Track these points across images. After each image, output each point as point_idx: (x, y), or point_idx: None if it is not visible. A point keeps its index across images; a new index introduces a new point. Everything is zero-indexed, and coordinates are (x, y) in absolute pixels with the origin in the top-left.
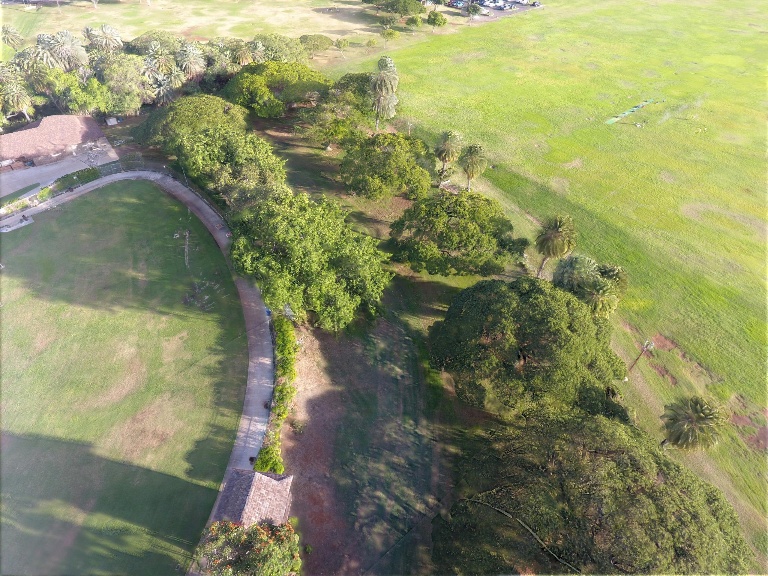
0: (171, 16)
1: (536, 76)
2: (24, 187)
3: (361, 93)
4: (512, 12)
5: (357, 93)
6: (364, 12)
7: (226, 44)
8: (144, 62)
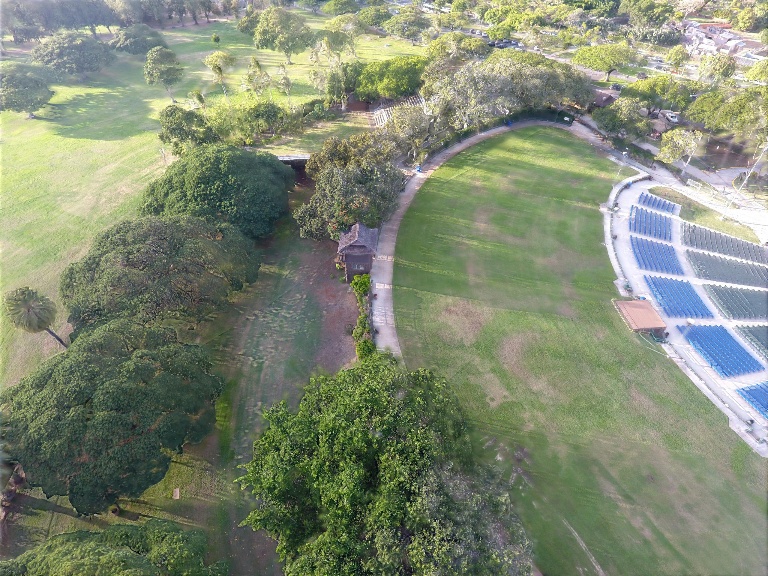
0: None
1: None
2: None
3: None
4: None
5: None
6: None
7: None
8: None
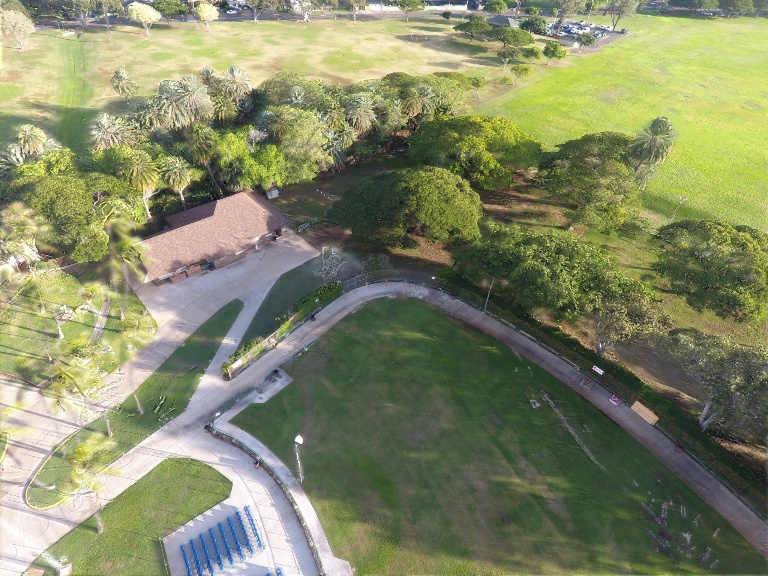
0: (243, 45)
1: (708, 119)
2: (221, 307)
3: (626, 162)
4: (607, 40)
5: (622, 162)
6: (454, 40)
7: (378, 88)
8: (316, 118)
